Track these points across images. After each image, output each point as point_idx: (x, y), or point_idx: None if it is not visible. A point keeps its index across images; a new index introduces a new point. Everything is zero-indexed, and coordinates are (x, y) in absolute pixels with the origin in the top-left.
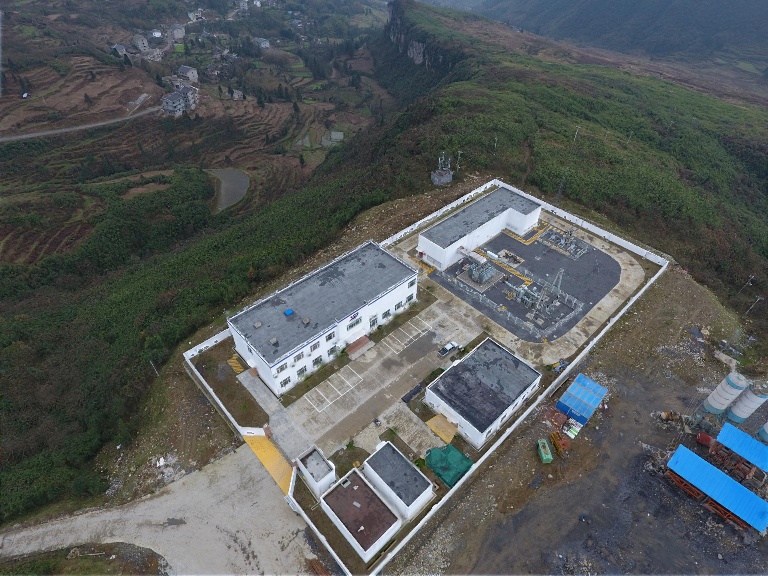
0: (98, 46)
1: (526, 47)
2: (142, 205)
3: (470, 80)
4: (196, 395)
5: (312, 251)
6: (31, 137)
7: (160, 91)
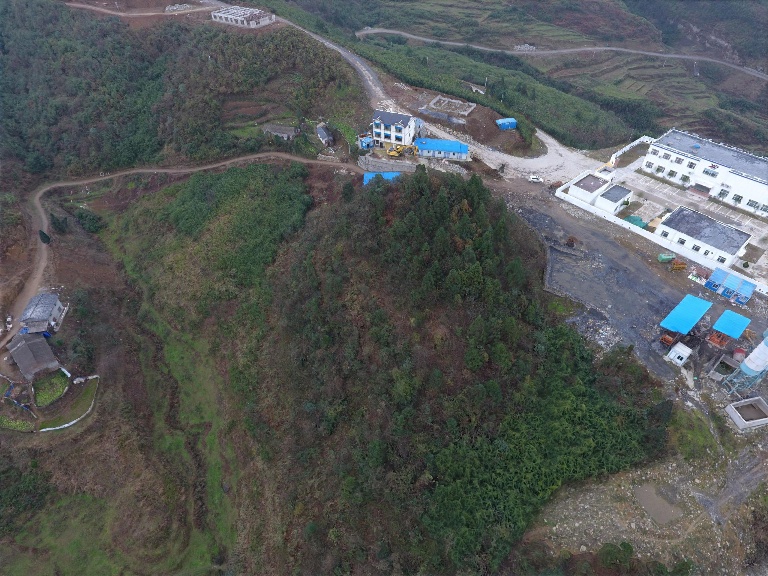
0: None
1: None
2: None
3: None
4: None
5: None
6: None
7: None
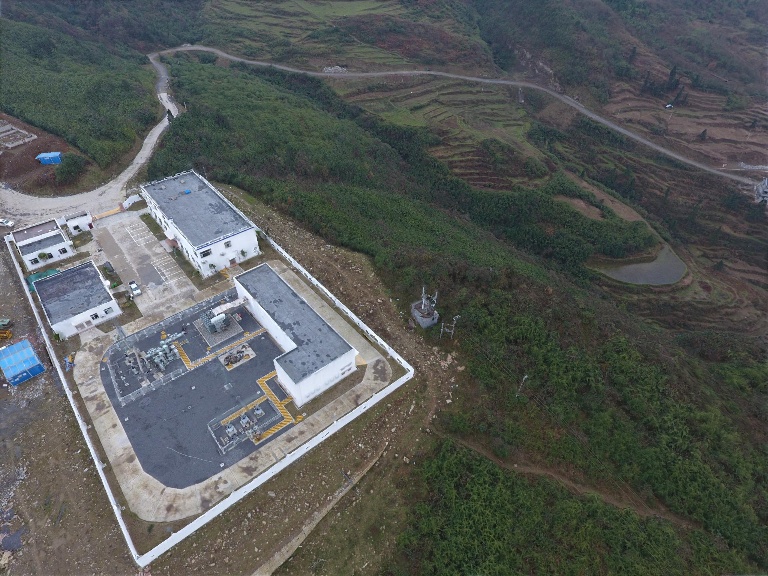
0: None
1: None
2: (550, 208)
3: None
4: None
5: (316, 231)
6: (620, 132)
7: None
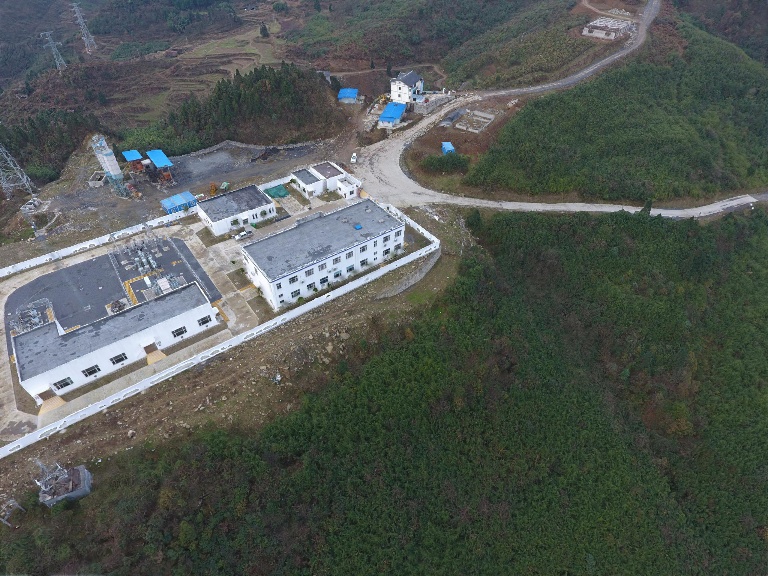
0: None
1: None
2: None
3: None
4: None
5: None
6: None
7: None
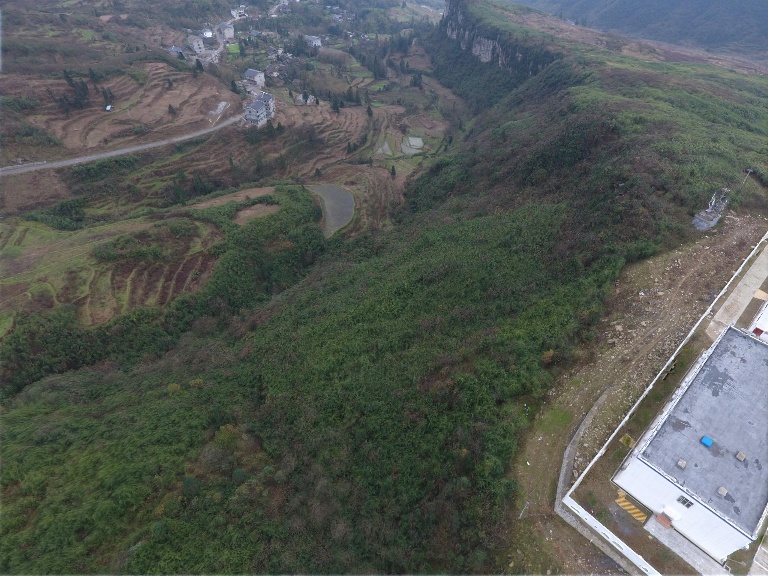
0: (164, 50)
1: (602, 42)
2: (260, 232)
3: (587, 84)
4: (593, 553)
5: (597, 322)
6: (120, 154)
7: (237, 98)
